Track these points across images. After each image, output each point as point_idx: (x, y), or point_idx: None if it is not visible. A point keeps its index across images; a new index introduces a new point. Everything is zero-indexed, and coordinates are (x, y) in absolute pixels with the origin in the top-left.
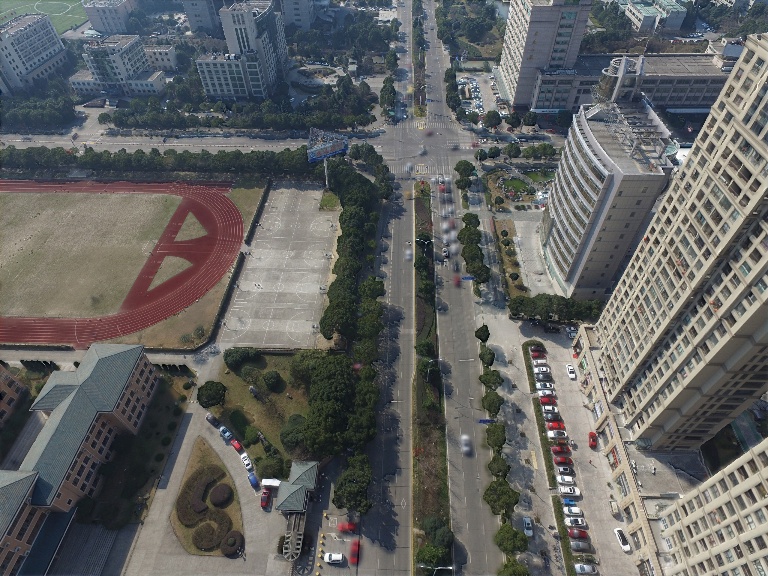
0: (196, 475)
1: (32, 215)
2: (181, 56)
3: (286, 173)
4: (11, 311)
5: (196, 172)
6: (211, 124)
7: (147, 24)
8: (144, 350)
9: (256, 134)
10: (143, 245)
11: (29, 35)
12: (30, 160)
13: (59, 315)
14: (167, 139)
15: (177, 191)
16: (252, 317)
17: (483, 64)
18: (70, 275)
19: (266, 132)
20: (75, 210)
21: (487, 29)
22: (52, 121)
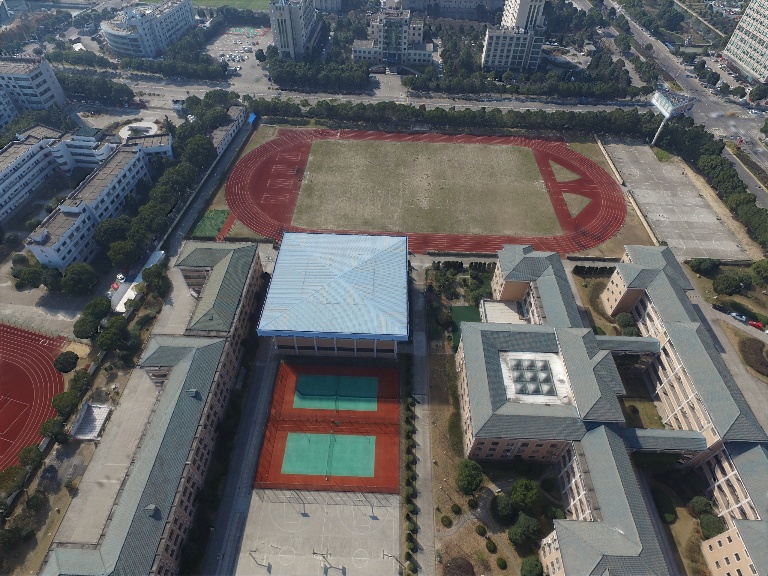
0: (743, 344)
1: (411, 159)
2: (428, 32)
3: (605, 132)
4: (471, 231)
5: (525, 129)
6: (508, 90)
7: (360, 3)
8: (616, 260)
9: (547, 100)
10: (534, 184)
11: (306, 6)
12: (383, 113)
13: (516, 234)
14: (470, 102)
15: (521, 143)
16: (680, 238)
17: (702, 49)
18: (494, 205)
19: (553, 99)
20: (446, 156)
21: (681, 20)
22: (361, 83)
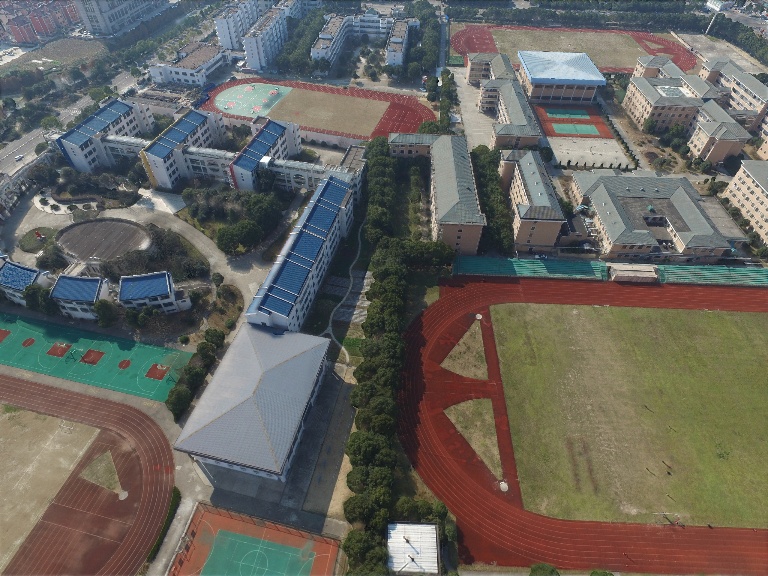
0: None
1: (557, 38)
2: None
3: (674, 28)
4: None
5: (622, 26)
6: (605, 7)
7: None
8: None
9: None
10: (638, 49)
11: None
12: (533, 14)
13: None
14: None
15: None
16: None
17: None
18: None
19: None
20: (578, 37)
21: None
22: (506, 2)
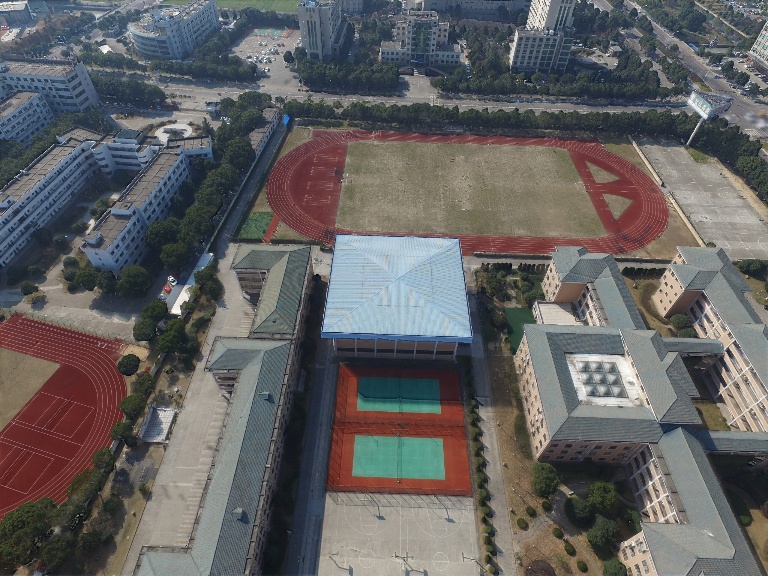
0: None
1: (449, 160)
2: (453, 33)
3: (638, 133)
4: (516, 232)
5: (558, 130)
6: (538, 91)
7: (382, 5)
8: (663, 261)
9: (577, 101)
10: (574, 185)
11: None
12: (418, 115)
13: (561, 236)
14: (501, 103)
15: (557, 145)
16: (725, 239)
17: (727, 50)
18: (536, 206)
19: (584, 100)
20: (483, 157)
21: (703, 20)
22: (391, 84)
